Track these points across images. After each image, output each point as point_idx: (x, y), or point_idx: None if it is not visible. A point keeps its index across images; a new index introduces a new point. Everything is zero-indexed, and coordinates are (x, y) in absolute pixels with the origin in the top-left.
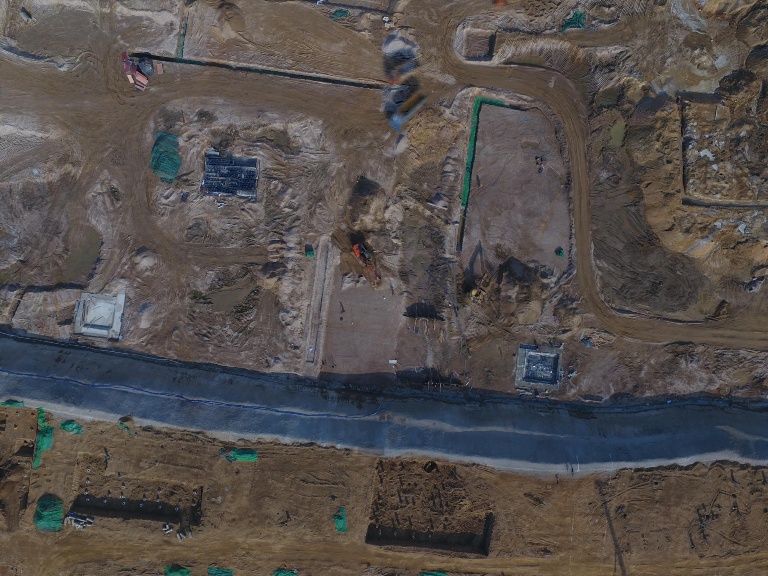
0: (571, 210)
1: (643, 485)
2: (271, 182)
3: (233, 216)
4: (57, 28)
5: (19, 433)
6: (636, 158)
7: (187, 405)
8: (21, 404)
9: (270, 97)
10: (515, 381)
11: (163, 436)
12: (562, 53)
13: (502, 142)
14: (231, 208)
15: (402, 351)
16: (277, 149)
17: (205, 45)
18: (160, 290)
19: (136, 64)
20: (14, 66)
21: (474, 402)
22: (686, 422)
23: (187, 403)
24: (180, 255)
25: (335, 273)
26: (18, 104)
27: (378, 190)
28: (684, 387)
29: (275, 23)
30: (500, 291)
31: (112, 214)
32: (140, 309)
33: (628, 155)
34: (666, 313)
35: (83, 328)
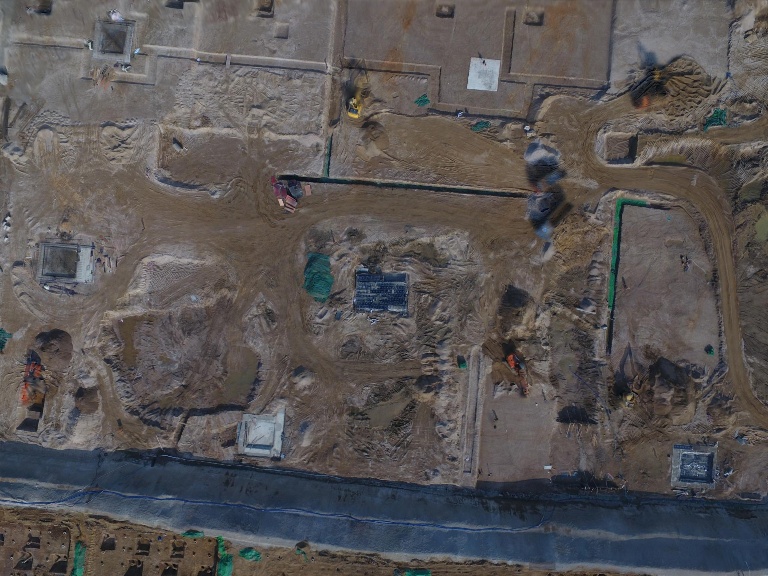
0: (719, 307)
1: None
2: (421, 296)
3: (386, 331)
4: (207, 156)
5: (197, 560)
6: None
7: (357, 526)
8: (201, 534)
9: (416, 212)
10: (671, 482)
11: (339, 559)
12: (703, 150)
13: (646, 242)
14: (383, 324)
15: (556, 456)
16: (425, 263)
17: (351, 164)
18: (318, 408)
19: (285, 187)
20: (170, 197)
21: (631, 504)
22: None
23: (357, 523)
24: (336, 373)
25: (487, 382)
26: (175, 234)
27: (528, 299)
28: None
29: (417, 138)
30: (653, 393)
31: (269, 336)
32: (301, 428)
33: None
34: None
35: (246, 449)
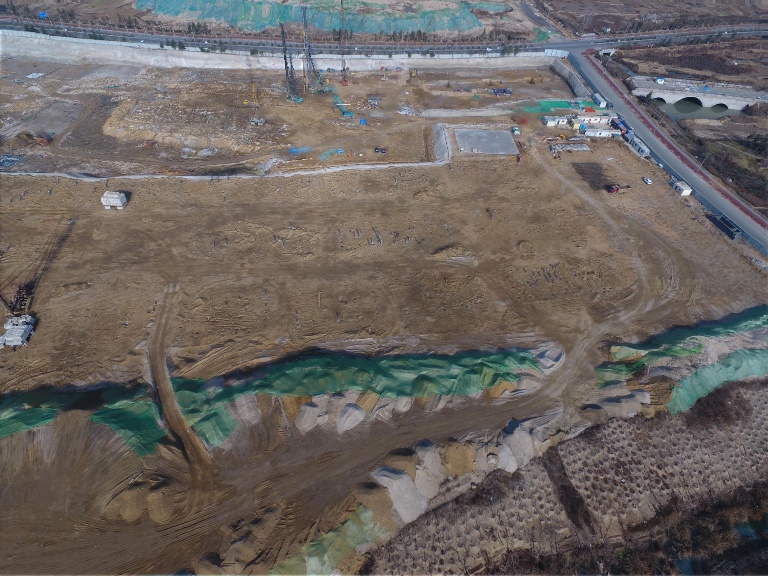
0: (70, 124)
1: None
2: None
3: None
4: None
5: None
6: None
7: None
8: None
9: None
10: None
11: None
12: (103, 94)
13: None
14: None
15: None
16: None
17: None
18: None
19: None
20: None
21: None
22: None
23: None
24: None
25: None
26: None
27: None
28: None
29: None
30: None
31: None
32: None
33: None
34: (88, 150)
35: None
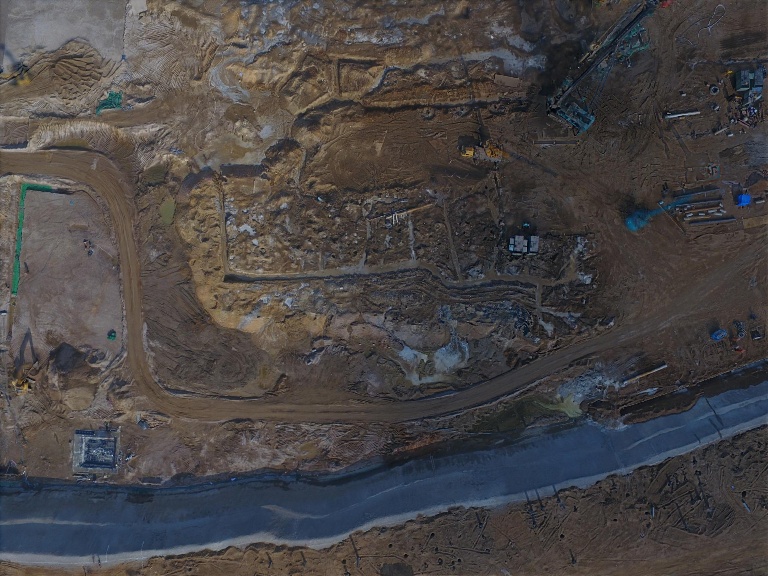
0: (121, 292)
1: (176, 572)
2: None
3: None
4: None
5: None
6: (183, 236)
7: None
8: None
9: None
10: (72, 467)
11: None
12: (104, 134)
13: (48, 227)
14: None
15: None
16: None
17: None
18: None
19: None
20: None
21: (32, 491)
22: (237, 502)
23: None
24: None
25: None
26: None
27: None
28: (245, 464)
29: None
30: (47, 379)
31: None
32: None
33: (177, 233)
34: (223, 390)
35: None
